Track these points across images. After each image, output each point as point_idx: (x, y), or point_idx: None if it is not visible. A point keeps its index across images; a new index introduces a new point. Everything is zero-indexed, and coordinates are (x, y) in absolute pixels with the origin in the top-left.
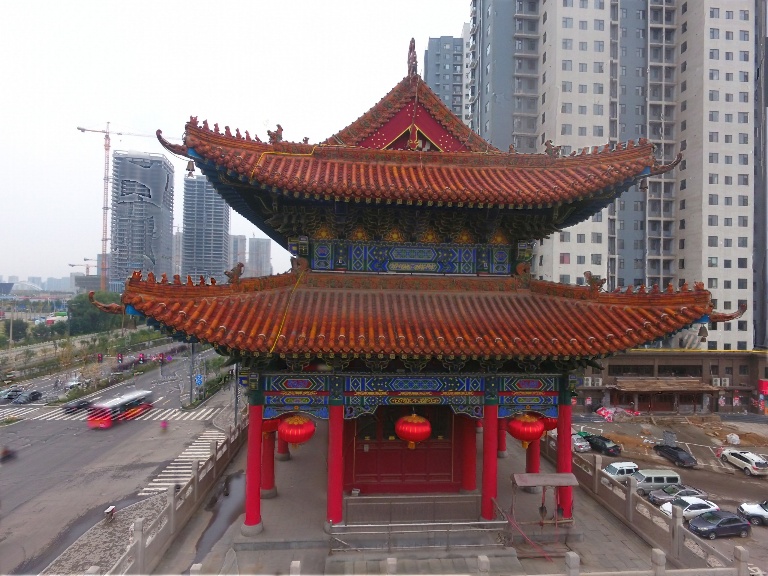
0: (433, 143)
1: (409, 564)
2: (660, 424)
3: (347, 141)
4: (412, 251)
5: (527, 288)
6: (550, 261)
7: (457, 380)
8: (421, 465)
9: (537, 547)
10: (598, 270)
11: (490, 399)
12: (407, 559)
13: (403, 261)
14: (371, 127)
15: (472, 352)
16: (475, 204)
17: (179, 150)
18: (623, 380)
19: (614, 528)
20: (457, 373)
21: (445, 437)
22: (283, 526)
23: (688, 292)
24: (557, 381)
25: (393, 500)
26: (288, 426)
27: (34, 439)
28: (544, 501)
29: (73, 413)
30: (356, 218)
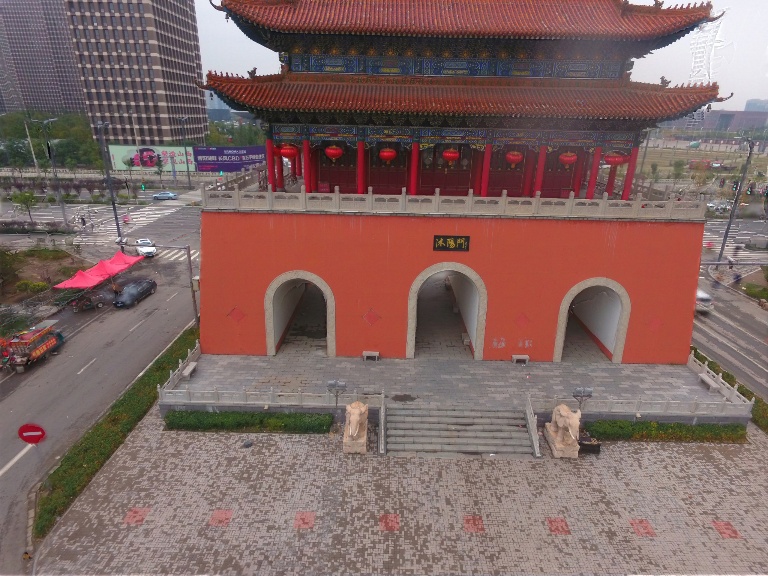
0: None
1: None
2: None
3: None
4: None
5: None
6: None
7: None
8: None
9: None
10: None
11: None
12: None
13: None
14: None
15: None
16: None
17: None
18: None
19: None
20: None
21: None
22: (301, 180)
23: None
24: None
25: None
26: None
27: None
28: None
29: None
30: None
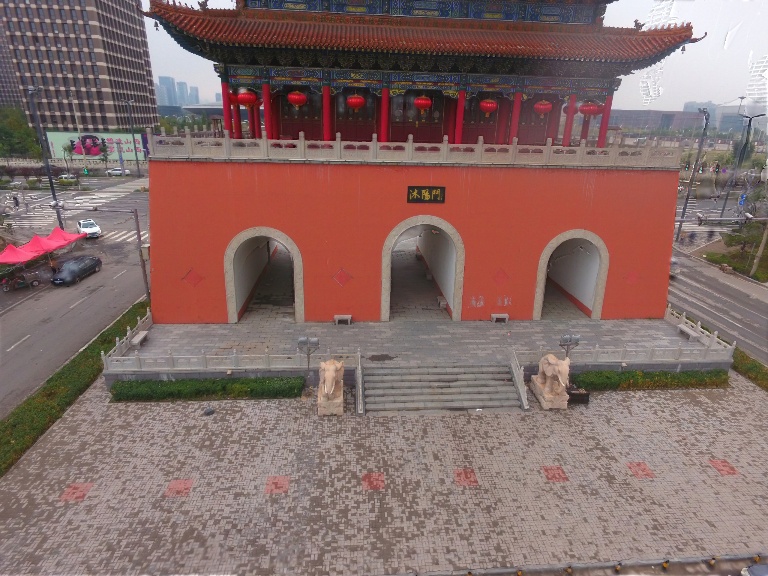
0: None
1: None
2: None
3: None
4: None
5: None
6: None
7: None
8: None
9: None
10: None
11: None
12: None
13: None
14: None
15: None
16: None
17: None
18: None
19: None
20: None
21: None
22: None
23: None
24: None
25: None
26: None
27: None
28: None
29: None
30: None
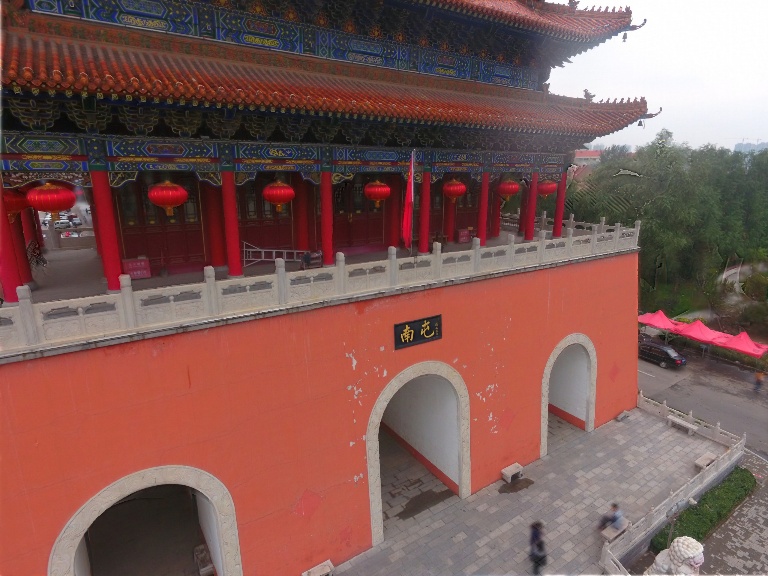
0: None
1: None
2: None
3: None
4: None
5: None
6: None
7: None
8: None
9: None
10: None
11: None
12: None
13: None
14: None
15: None
16: None
17: None
18: None
19: None
20: None
21: None
22: None
23: None
24: None
25: None
26: None
27: None
28: None
29: None
30: None
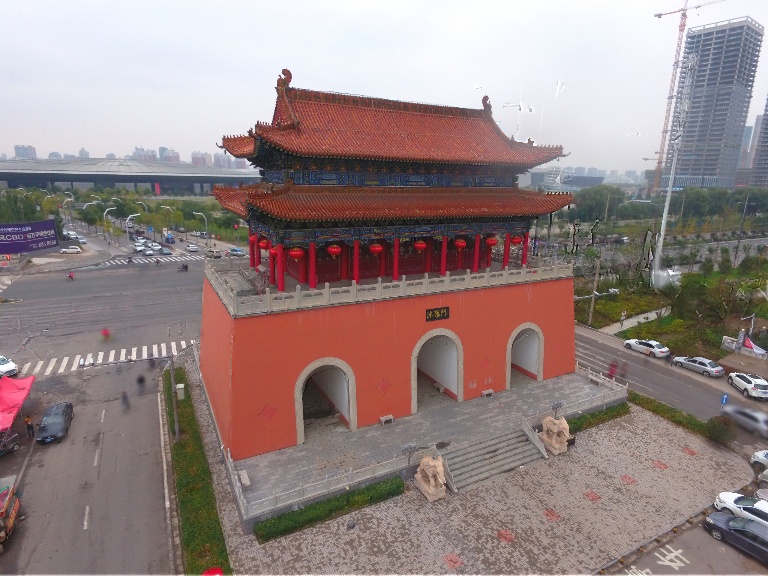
0: None
1: None
2: None
3: None
4: (274, 174)
5: None
6: None
7: None
8: None
9: None
10: None
11: None
12: None
13: None
14: None
15: None
16: None
17: None
18: None
19: None
20: None
21: None
22: None
23: None
24: None
25: None
26: None
27: None
28: None
29: None
30: None
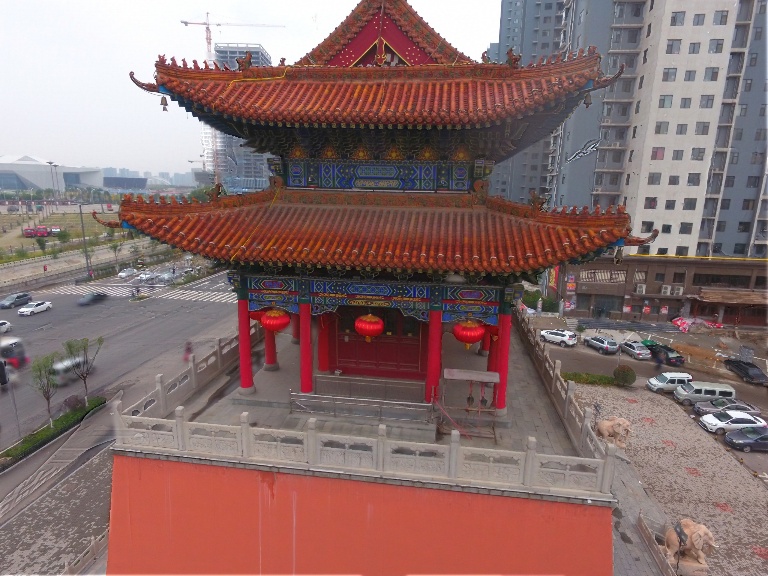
0: (400, 57)
1: (347, 426)
2: (744, 339)
3: (319, 59)
4: (375, 169)
5: (483, 204)
6: (640, 157)
7: (405, 288)
8: (393, 356)
9: (466, 428)
10: (698, 167)
11: (434, 305)
12: (347, 423)
13: (367, 178)
14: (340, 44)
15: (395, 266)
16: (414, 126)
17: (151, 88)
18: (709, 290)
19: (549, 422)
20: (405, 282)
21: (414, 335)
22: (271, 391)
23: (611, 215)
24: (498, 293)
25: (352, 380)
26: (266, 317)
27: (158, 313)
28: (471, 393)
29: (187, 294)
30: (323, 138)
